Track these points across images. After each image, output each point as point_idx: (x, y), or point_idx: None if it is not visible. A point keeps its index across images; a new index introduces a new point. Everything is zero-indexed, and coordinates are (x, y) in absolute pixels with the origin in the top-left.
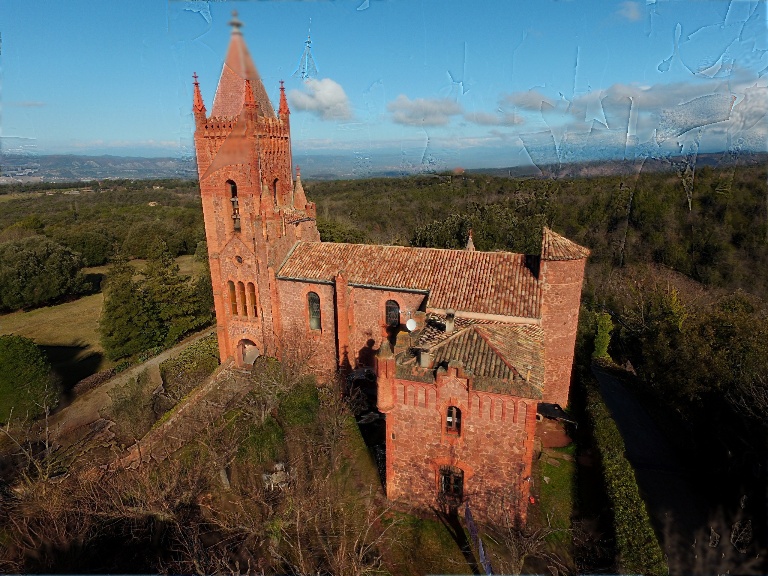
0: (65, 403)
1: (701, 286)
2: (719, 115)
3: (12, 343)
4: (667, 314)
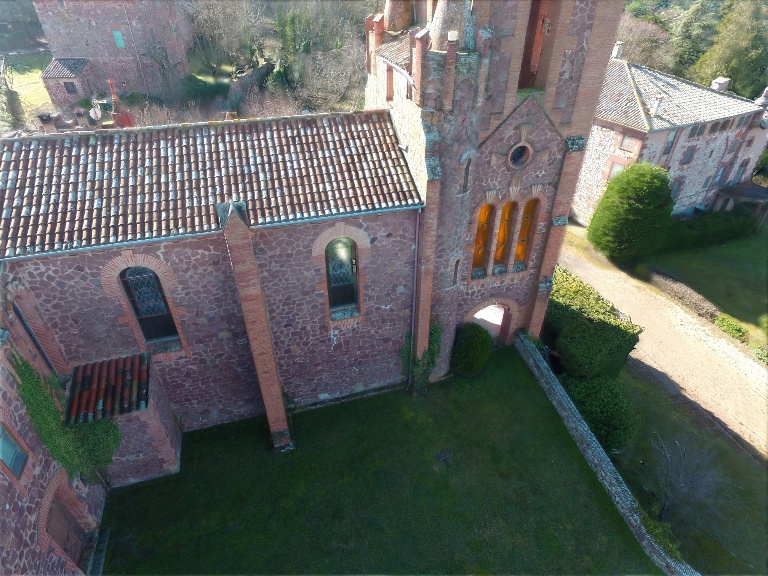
0: (637, 274)
1: None
2: None
3: (636, 170)
4: None
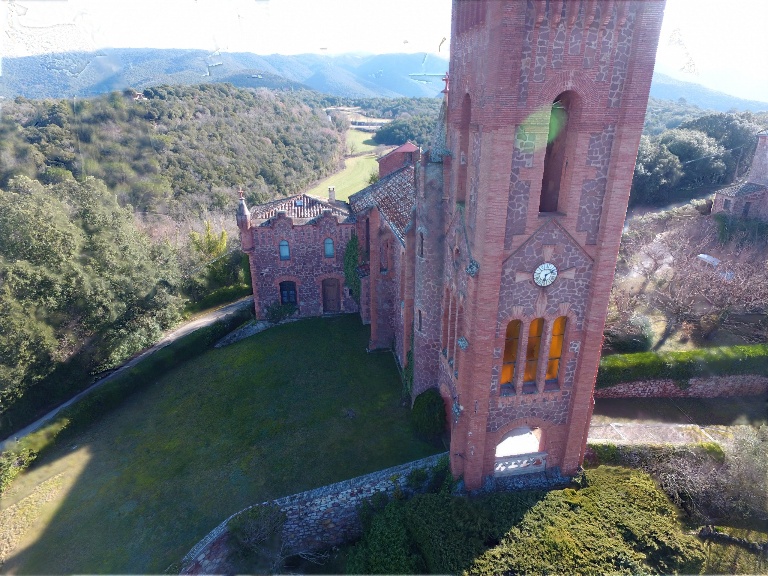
0: None
1: (173, 220)
2: (86, 49)
3: None
4: (217, 242)
